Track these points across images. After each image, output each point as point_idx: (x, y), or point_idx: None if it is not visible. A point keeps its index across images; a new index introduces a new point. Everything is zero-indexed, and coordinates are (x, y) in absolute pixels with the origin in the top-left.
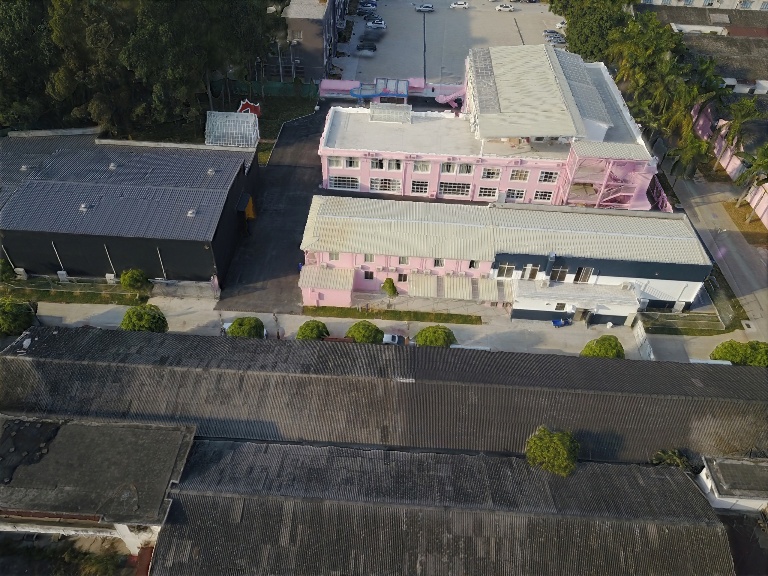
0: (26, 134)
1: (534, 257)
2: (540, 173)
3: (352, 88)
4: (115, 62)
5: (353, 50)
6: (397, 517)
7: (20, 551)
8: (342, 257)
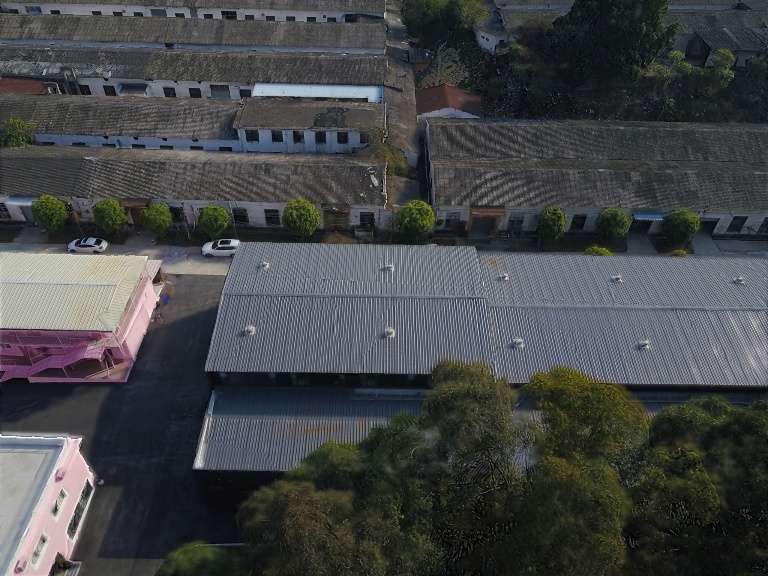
0: None
1: None
2: None
3: None
4: None
5: None
6: None
7: None
8: None
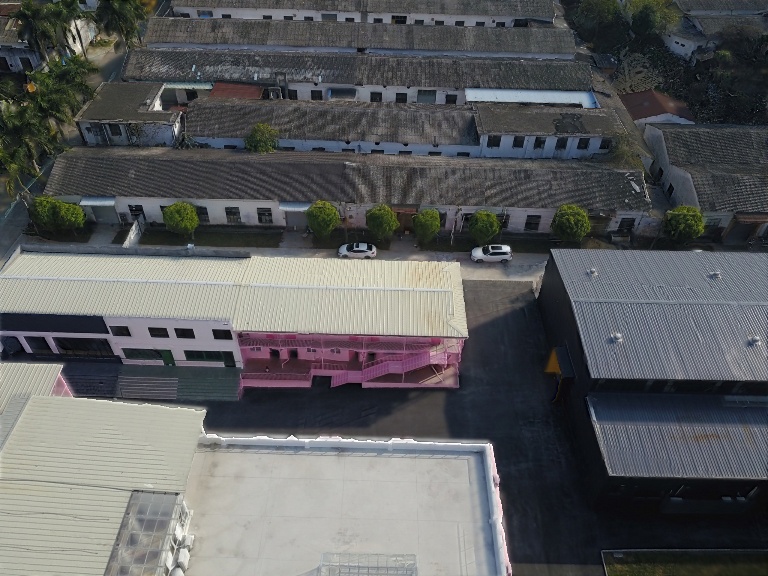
0: None
1: None
2: None
3: None
4: None
5: None
6: (358, 107)
7: None
8: None
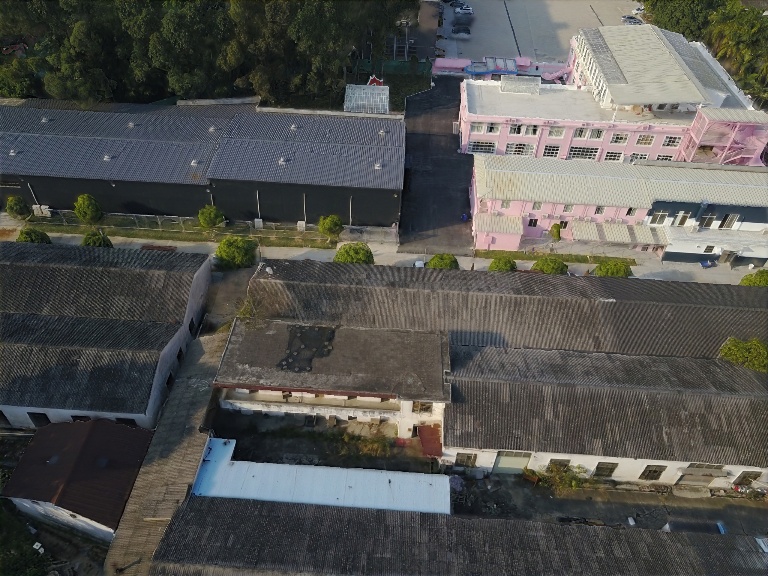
0: (192, 103)
1: (688, 204)
2: (665, 138)
3: (464, 66)
4: (282, 36)
5: (449, 33)
6: (640, 398)
7: (304, 434)
8: (513, 205)
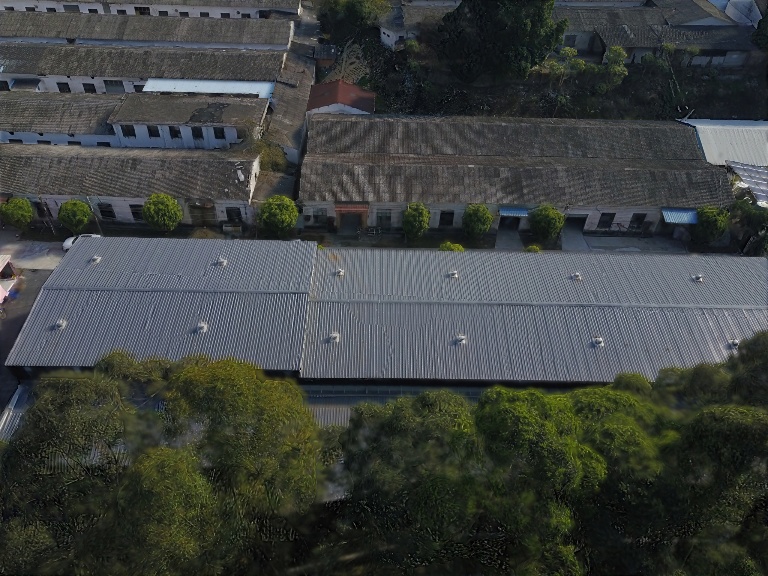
0: None
1: None
2: None
3: None
4: None
5: None
6: None
7: None
8: None
